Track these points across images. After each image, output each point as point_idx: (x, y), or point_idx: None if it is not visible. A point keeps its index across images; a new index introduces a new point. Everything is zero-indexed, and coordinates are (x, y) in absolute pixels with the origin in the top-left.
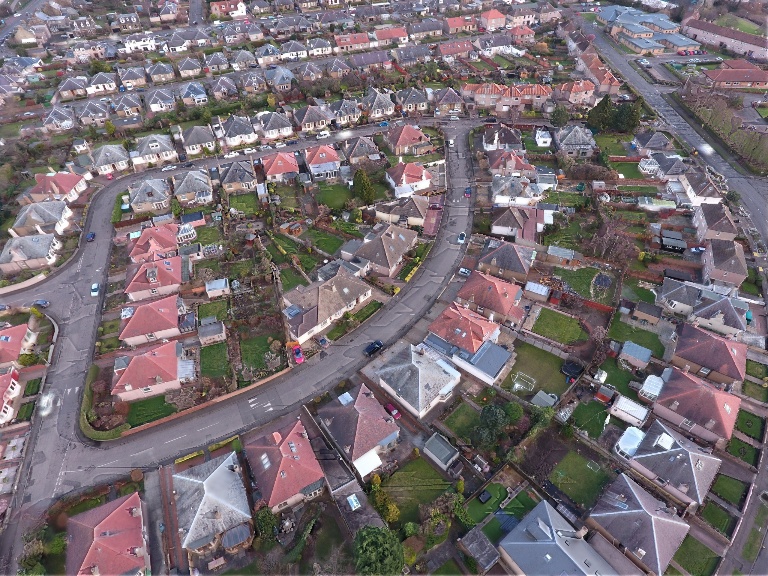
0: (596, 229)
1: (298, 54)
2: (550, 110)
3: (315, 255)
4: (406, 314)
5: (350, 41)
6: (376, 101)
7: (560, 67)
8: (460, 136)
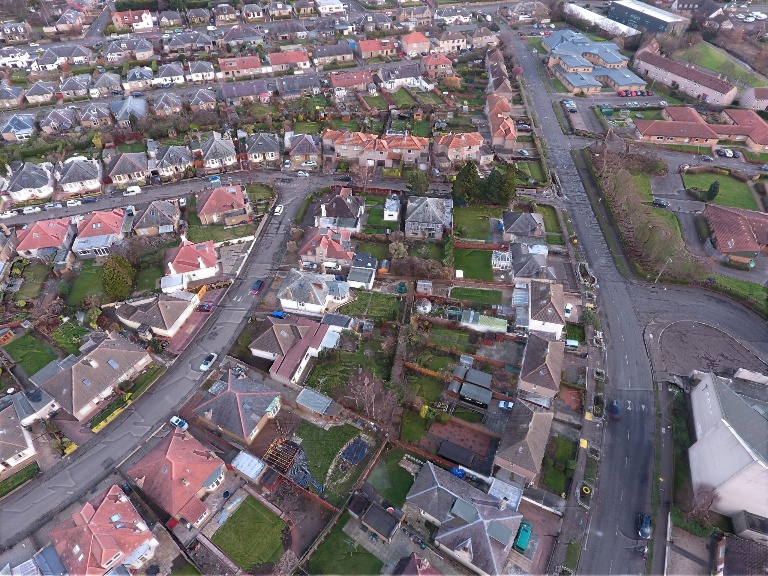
0: (385, 360)
1: (173, 79)
2: (423, 168)
3: (5, 379)
4: (61, 491)
5: (237, 65)
6: (211, 149)
7: (465, 108)
8: (296, 200)
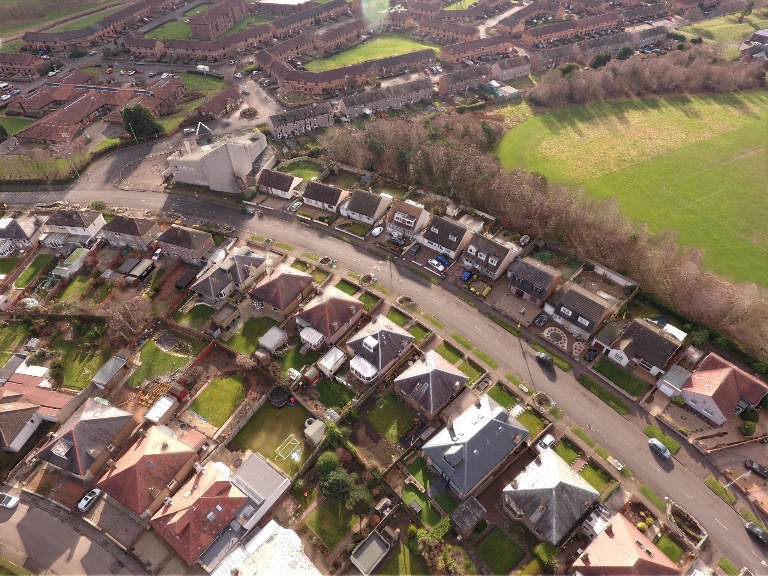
0: (84, 326)
1: None
2: None
3: None
4: None
5: None
6: None
7: None
8: None
